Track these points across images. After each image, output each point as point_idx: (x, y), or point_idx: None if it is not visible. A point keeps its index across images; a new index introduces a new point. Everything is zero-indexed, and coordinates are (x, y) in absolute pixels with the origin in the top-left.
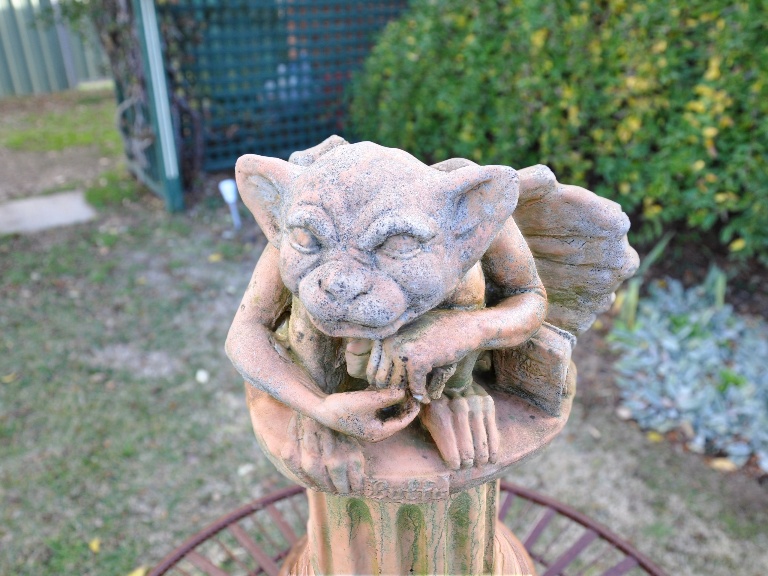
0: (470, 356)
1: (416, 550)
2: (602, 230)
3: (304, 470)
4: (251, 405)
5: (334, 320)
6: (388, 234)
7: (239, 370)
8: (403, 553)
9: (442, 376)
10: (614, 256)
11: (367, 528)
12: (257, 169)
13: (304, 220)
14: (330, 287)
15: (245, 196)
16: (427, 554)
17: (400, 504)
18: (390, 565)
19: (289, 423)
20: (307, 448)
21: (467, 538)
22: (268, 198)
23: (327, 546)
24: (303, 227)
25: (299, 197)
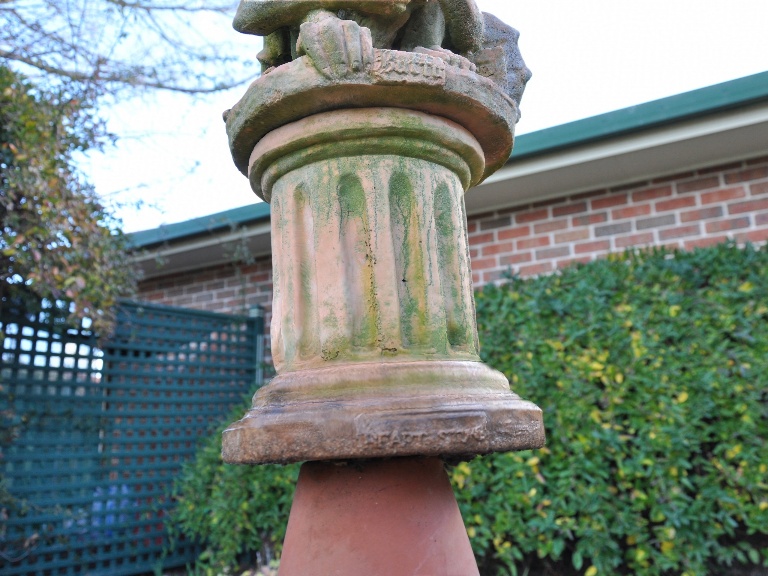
0: (439, 14)
1: (407, 250)
2: (503, 33)
3: (324, 28)
4: None
5: None
6: None
7: None
8: (395, 251)
9: None
10: (515, 58)
11: (356, 225)
12: None
13: None
14: None
15: None
16: (421, 238)
17: (391, 170)
18: (385, 249)
19: None
20: (324, 18)
21: (453, 249)
22: None
23: (305, 293)
24: None
25: None
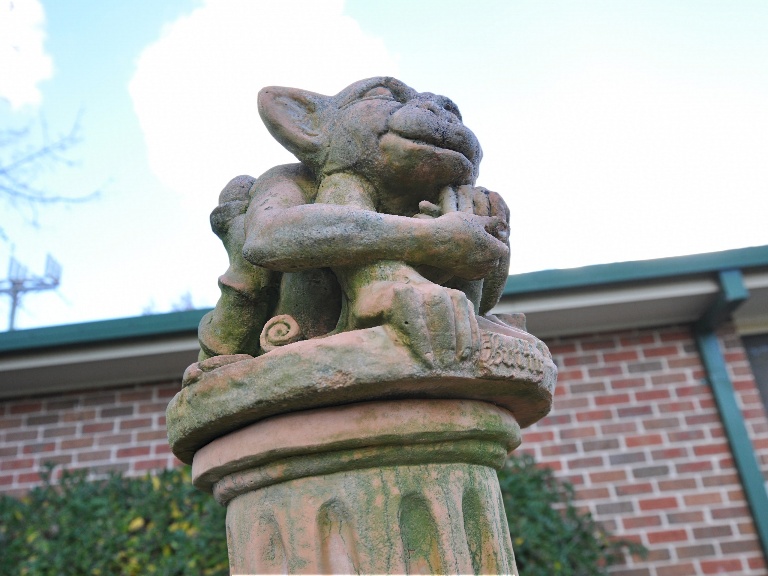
0: None
1: None
2: None
3: (433, 298)
4: None
5: (440, 130)
6: (447, 102)
7: (306, 228)
8: None
9: (507, 226)
10: None
11: (420, 573)
12: (288, 90)
13: (385, 77)
14: (433, 104)
15: (273, 110)
16: None
17: (462, 486)
18: None
19: (375, 287)
20: (424, 281)
21: None
22: (295, 117)
23: None
24: (382, 85)
25: (362, 80)
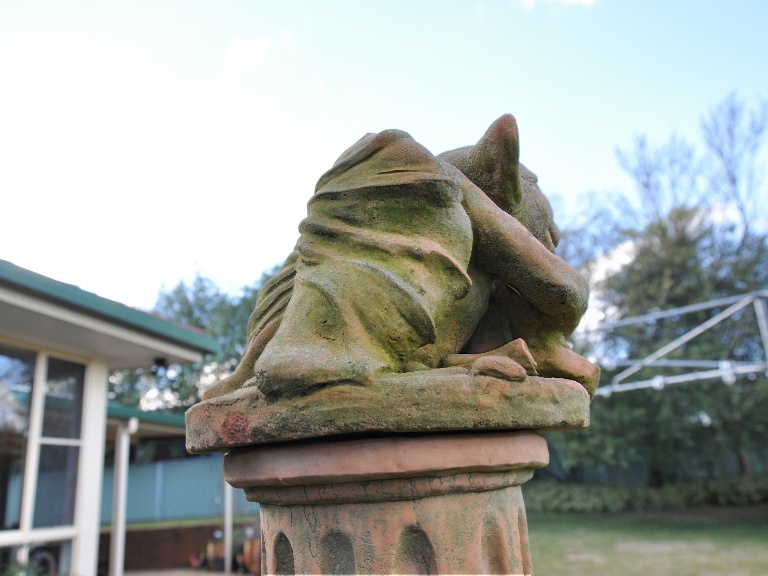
0: None
1: None
2: None
3: None
4: (562, 381)
5: None
6: None
7: None
8: None
9: None
10: None
11: None
12: None
13: None
14: None
15: None
16: None
17: None
18: None
19: (574, 354)
20: None
21: None
22: None
23: None
24: None
25: None
